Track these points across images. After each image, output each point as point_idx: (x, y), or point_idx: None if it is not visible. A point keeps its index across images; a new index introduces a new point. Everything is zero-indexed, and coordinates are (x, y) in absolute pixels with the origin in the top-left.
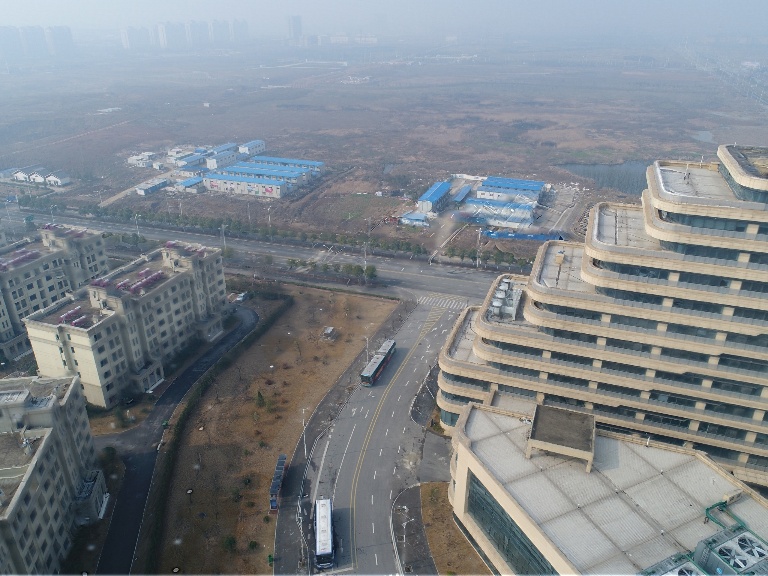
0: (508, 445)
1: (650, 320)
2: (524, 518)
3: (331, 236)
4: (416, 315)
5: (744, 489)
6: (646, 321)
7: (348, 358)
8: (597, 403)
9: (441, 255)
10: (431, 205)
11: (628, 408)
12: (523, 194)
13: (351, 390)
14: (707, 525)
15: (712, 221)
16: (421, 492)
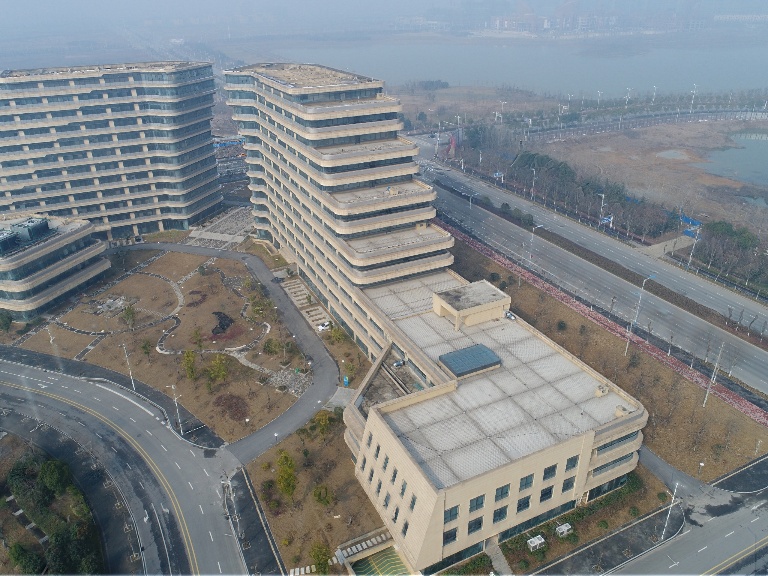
0: None
1: None
2: None
3: None
4: None
5: (50, 217)
6: None
7: None
8: None
9: None
10: None
11: None
12: None
13: None
14: None
15: None
16: None
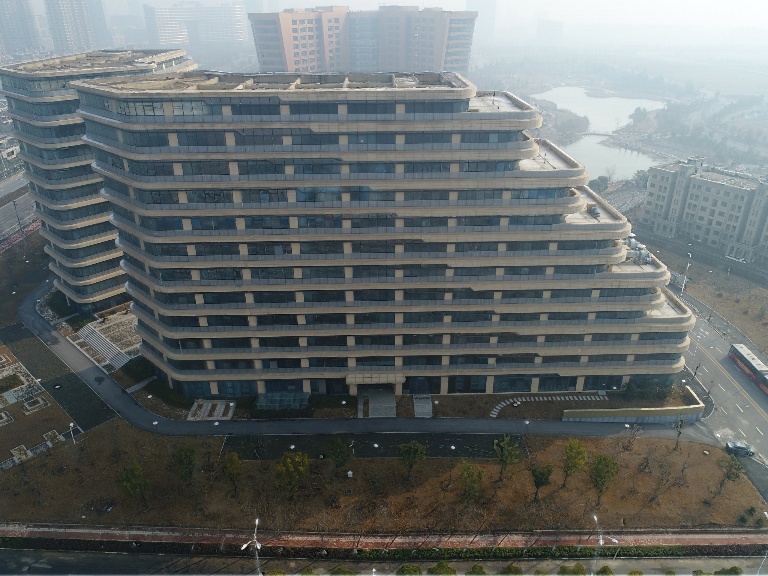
0: None
1: None
2: None
3: None
4: None
5: None
6: None
7: None
8: None
9: None
10: None
11: None
12: None
13: None
14: None
15: None
16: None
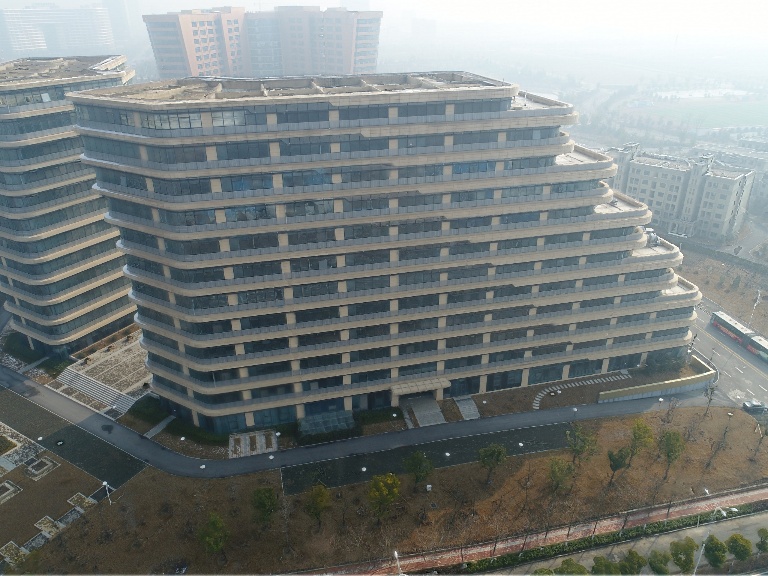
0: None
1: None
2: None
3: None
4: None
5: None
6: None
7: None
8: None
9: None
10: None
11: None
12: None
13: None
14: None
15: None
16: None
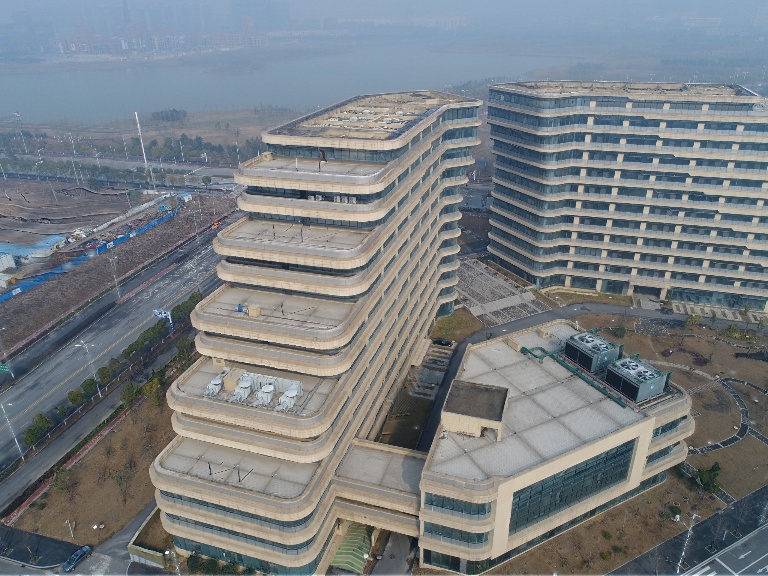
0: (486, 452)
1: None
2: None
3: None
4: None
5: None
6: None
7: None
8: None
9: None
10: None
11: None
12: None
13: None
14: (544, 363)
15: None
16: None
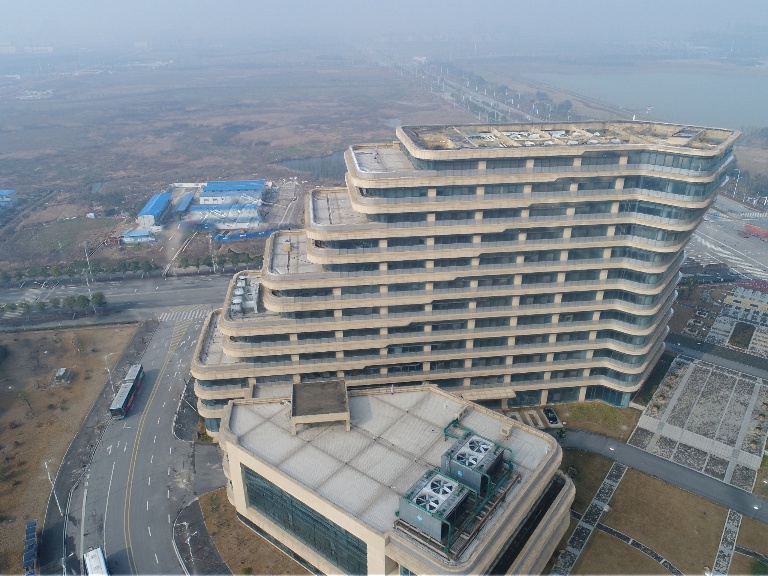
0: (274, 429)
1: (373, 285)
2: (300, 489)
3: (41, 270)
4: (160, 333)
5: (468, 405)
6: (370, 287)
7: (91, 396)
8: (347, 370)
9: (175, 268)
10: (153, 219)
11: (373, 367)
12: (246, 194)
13: (101, 428)
14: (447, 442)
15: (401, 191)
16: (201, 505)
